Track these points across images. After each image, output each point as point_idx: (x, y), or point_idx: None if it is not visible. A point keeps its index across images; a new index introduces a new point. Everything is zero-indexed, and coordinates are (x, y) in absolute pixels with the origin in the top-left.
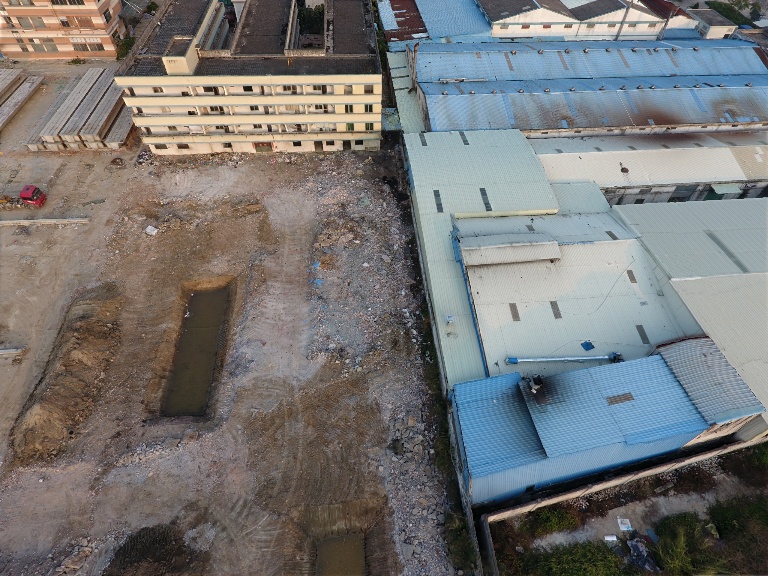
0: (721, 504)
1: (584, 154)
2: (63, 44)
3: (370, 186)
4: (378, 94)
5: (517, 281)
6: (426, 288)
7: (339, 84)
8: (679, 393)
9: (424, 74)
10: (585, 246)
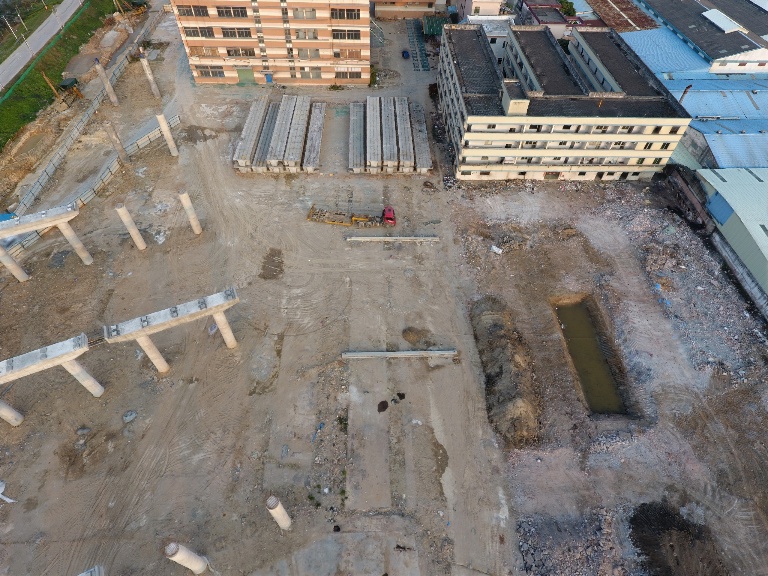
0: None
1: None
2: (328, 72)
3: (662, 215)
4: (680, 134)
5: None
6: None
7: (651, 125)
8: None
9: None
10: None
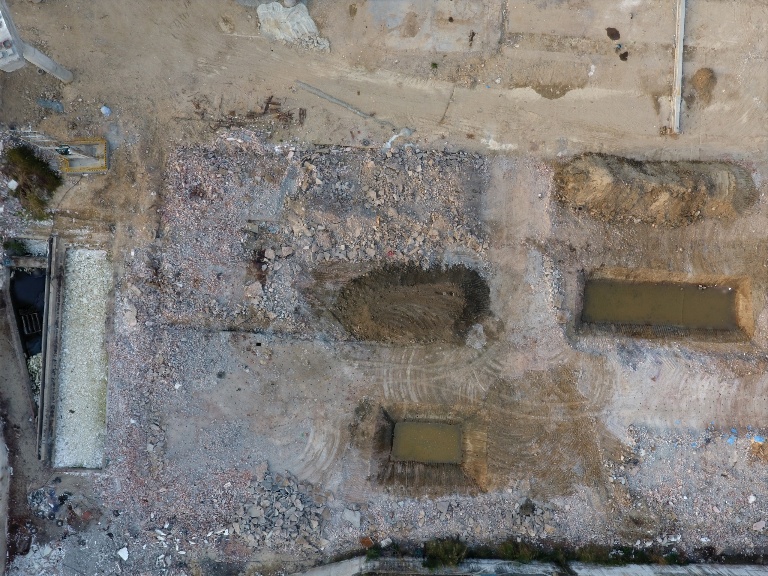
0: None
1: None
2: None
3: None
4: None
5: None
6: (707, 572)
7: None
8: None
9: None
10: None
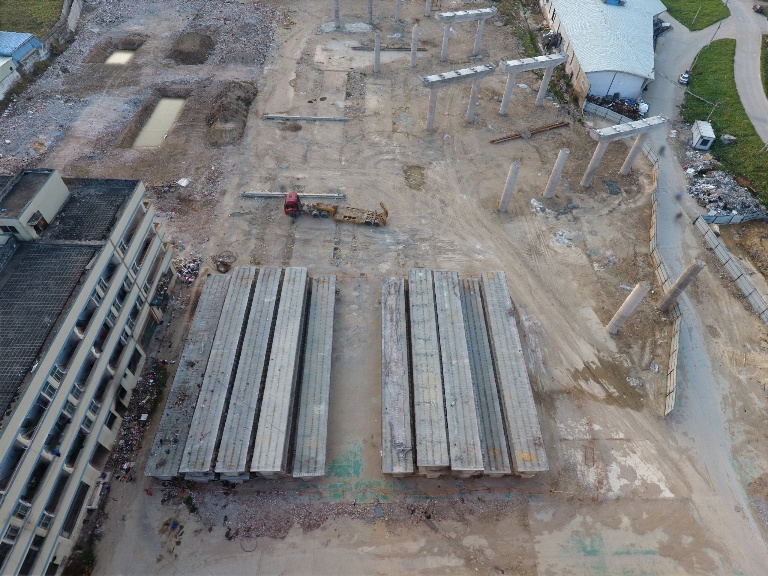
0: None
1: None
2: None
3: None
4: None
5: None
6: None
7: None
8: None
9: None
10: None
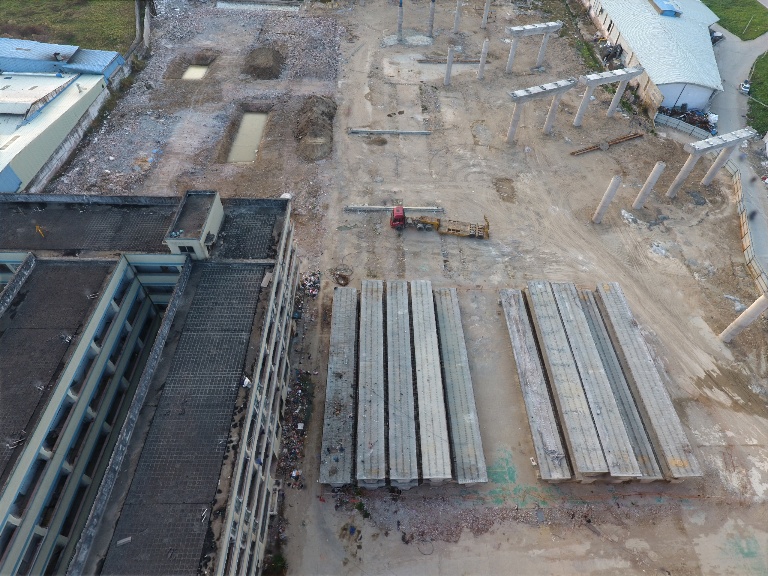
0: None
1: None
2: None
3: None
4: None
5: None
6: None
7: None
8: None
9: None
10: None
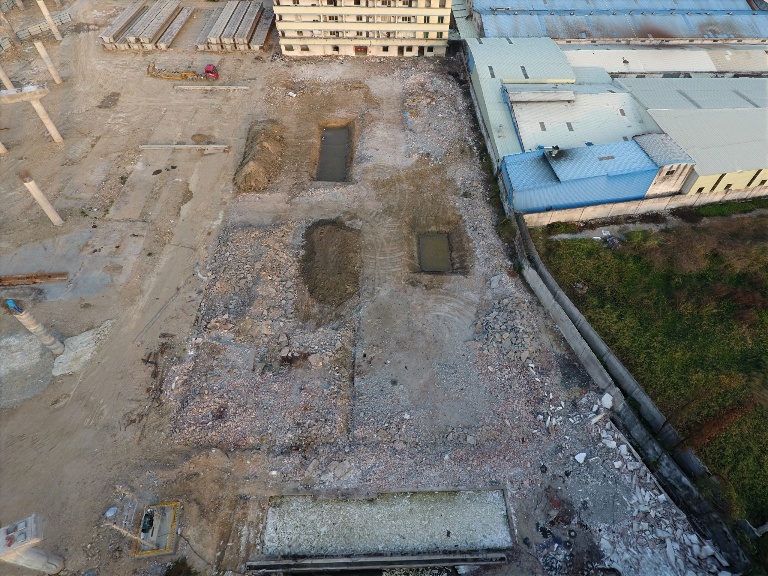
0: (668, 229)
1: (597, 51)
2: None
3: (439, 76)
4: (448, 8)
5: (545, 111)
6: (482, 125)
7: None
8: (643, 156)
9: (479, 4)
10: (592, 95)
